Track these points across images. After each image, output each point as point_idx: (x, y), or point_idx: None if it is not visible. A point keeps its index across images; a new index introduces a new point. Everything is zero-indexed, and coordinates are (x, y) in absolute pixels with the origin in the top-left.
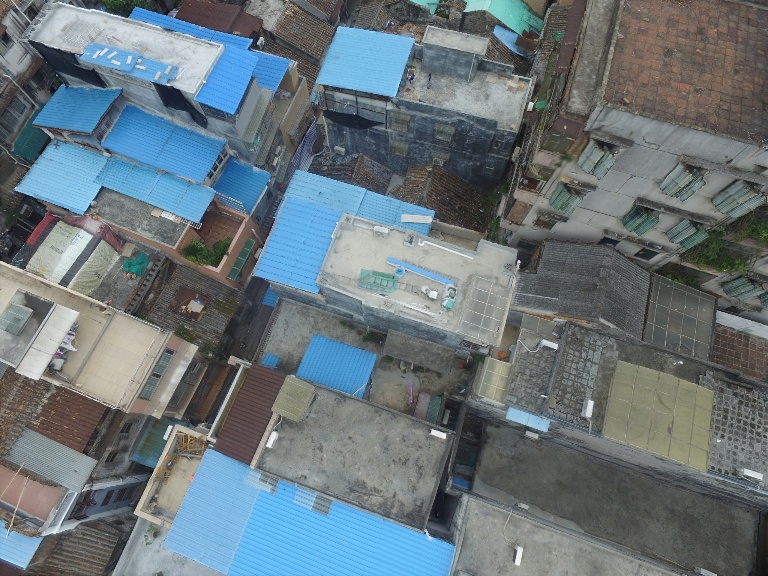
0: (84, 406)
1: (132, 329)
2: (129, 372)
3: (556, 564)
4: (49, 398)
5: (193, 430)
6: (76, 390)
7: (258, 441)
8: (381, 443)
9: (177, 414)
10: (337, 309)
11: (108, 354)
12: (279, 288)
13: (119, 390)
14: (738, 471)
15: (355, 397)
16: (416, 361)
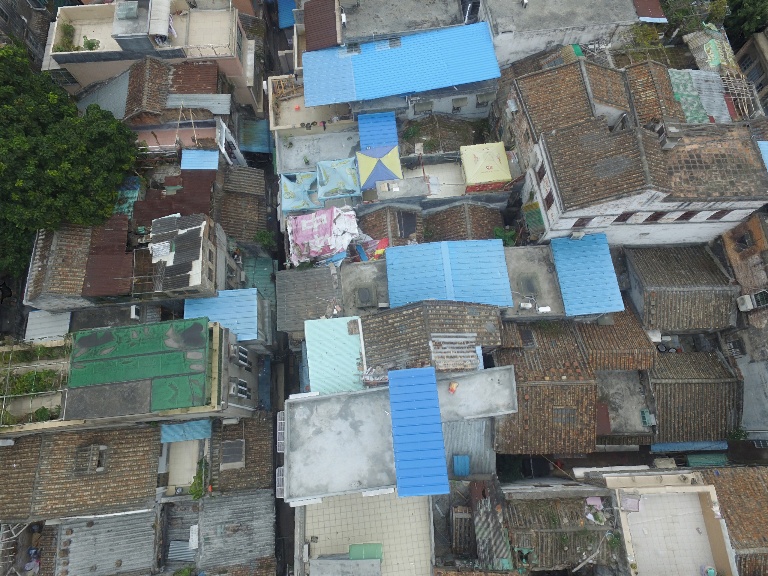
0: (201, 71)
1: (208, 16)
2: (222, 38)
3: None
4: (173, 74)
5: None
6: (190, 63)
7: (334, 31)
8: None
9: (258, 109)
10: None
11: (200, 34)
12: None
13: (221, 49)
14: None
15: None
16: None
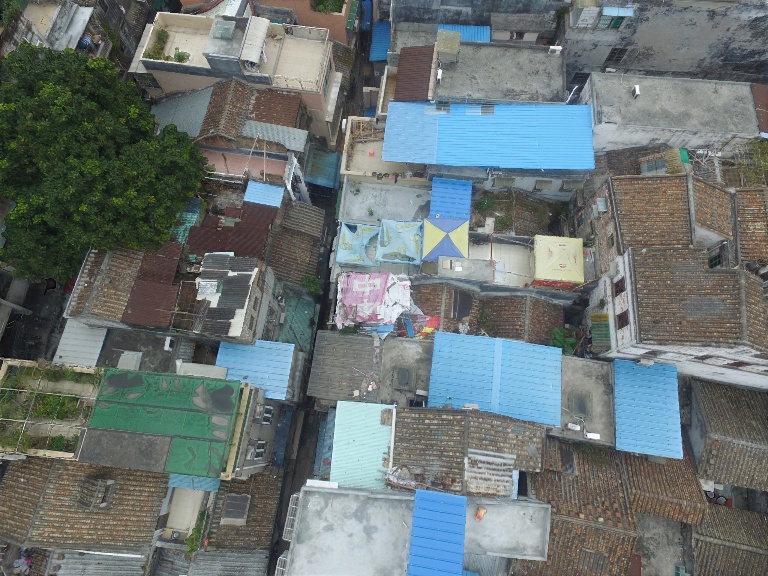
0: (283, 101)
1: (301, 45)
2: (311, 70)
3: (662, 94)
4: (255, 99)
5: (363, 117)
6: (274, 91)
7: (427, 85)
8: (516, 66)
9: (331, 142)
10: (448, 9)
11: (290, 63)
12: (401, 2)
13: (308, 82)
14: (765, 1)
15: (488, 42)
16: (518, 28)
